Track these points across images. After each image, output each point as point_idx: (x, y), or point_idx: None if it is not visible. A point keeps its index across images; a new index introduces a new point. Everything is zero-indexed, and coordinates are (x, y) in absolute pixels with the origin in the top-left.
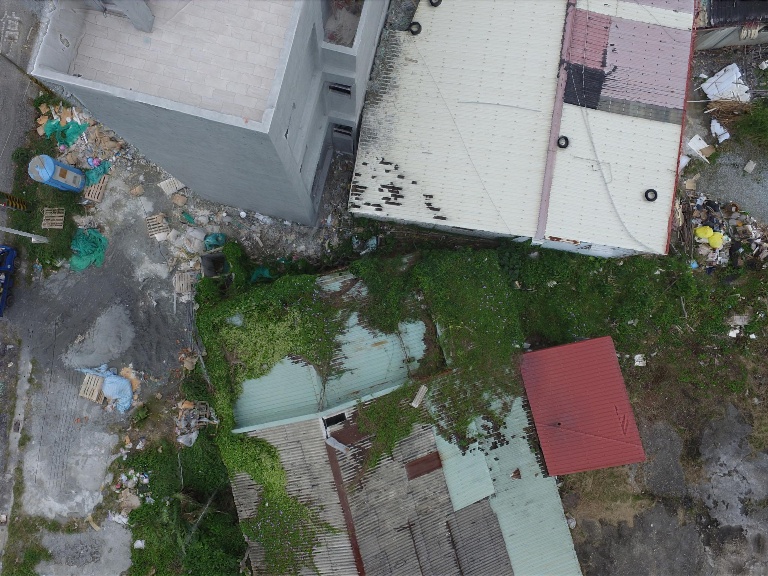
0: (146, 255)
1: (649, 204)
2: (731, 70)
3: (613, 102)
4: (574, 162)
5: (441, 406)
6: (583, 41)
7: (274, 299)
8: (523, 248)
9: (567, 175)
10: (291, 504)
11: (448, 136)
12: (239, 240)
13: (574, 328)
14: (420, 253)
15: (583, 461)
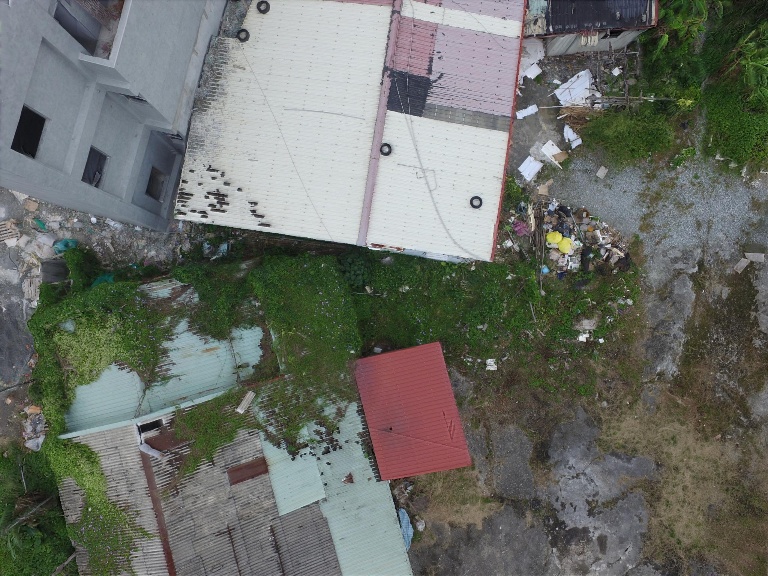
0: None
1: (474, 211)
2: (584, 76)
3: (439, 109)
4: (398, 169)
5: (270, 411)
6: (408, 49)
7: (94, 306)
8: (373, 253)
9: (390, 182)
10: (110, 509)
11: (274, 143)
12: (90, 246)
13: (420, 333)
14: (260, 259)
15: (413, 465)
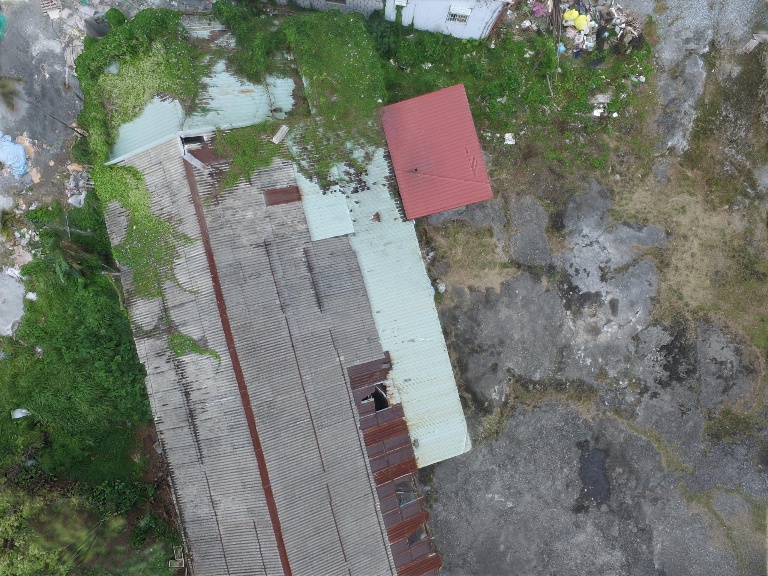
0: (40, 32)
1: None
2: None
3: None
4: None
5: (303, 148)
6: None
7: (140, 33)
8: (397, 28)
9: None
10: (154, 222)
11: None
12: (129, 20)
13: None
14: None
15: (437, 202)
